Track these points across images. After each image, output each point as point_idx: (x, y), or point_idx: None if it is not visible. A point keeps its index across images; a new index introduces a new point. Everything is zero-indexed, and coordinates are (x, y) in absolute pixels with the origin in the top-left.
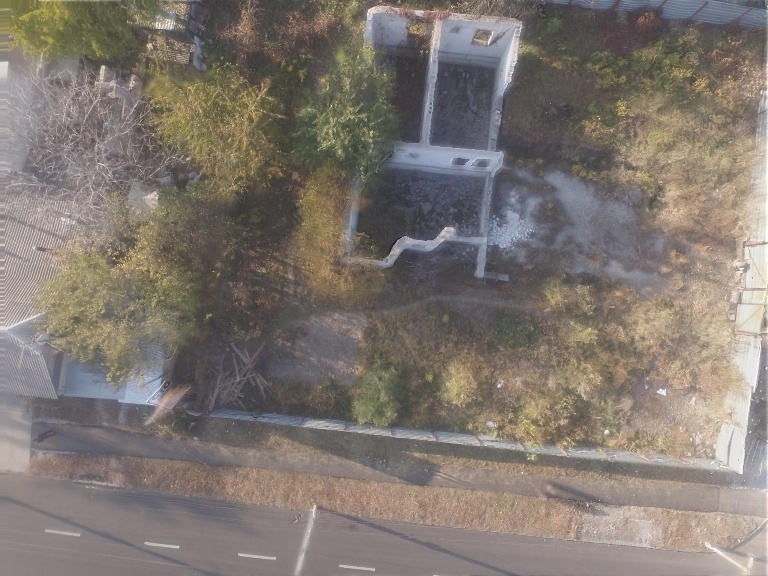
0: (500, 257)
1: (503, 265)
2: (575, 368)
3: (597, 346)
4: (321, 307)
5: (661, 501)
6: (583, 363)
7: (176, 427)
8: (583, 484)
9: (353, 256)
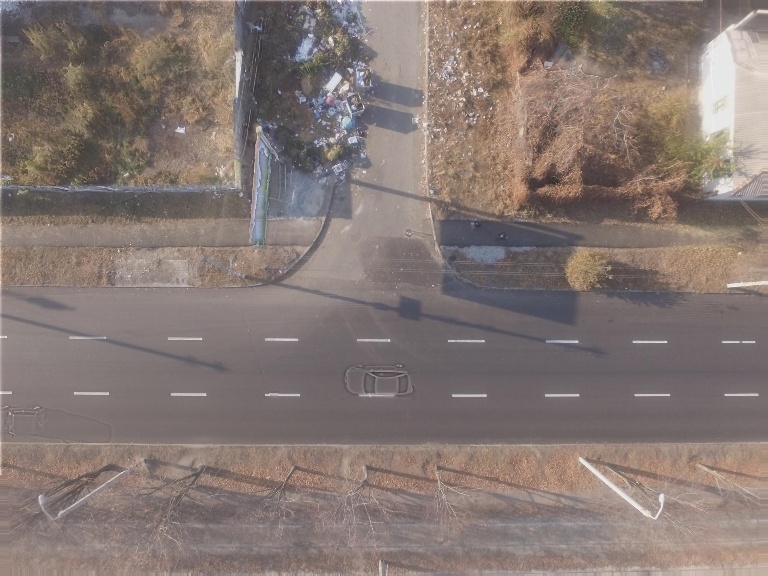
0: (7, 20)
1: (14, 28)
2: (77, 110)
3: (102, 89)
4: None
5: (195, 240)
6: None
7: None
8: (112, 230)
9: None
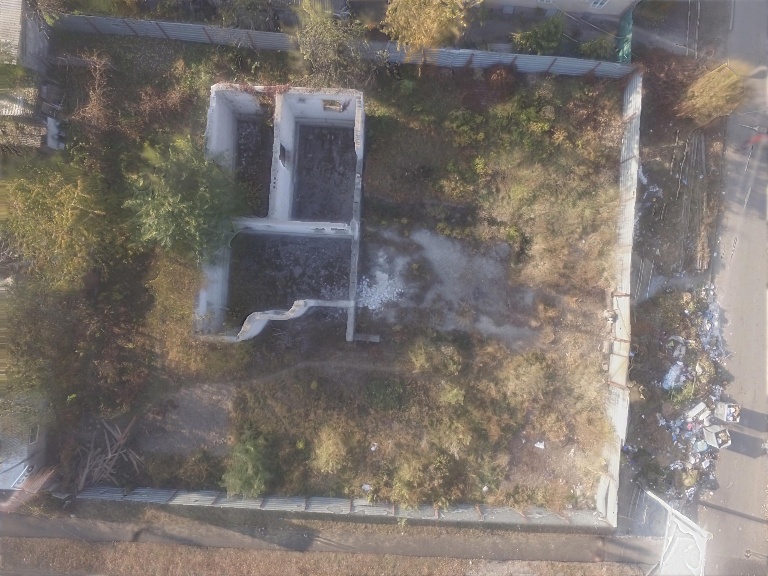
0: (370, 319)
1: (374, 326)
2: (447, 428)
3: (470, 404)
4: (190, 379)
5: (545, 554)
6: (455, 422)
7: (46, 508)
8: (465, 541)
9: (205, 334)
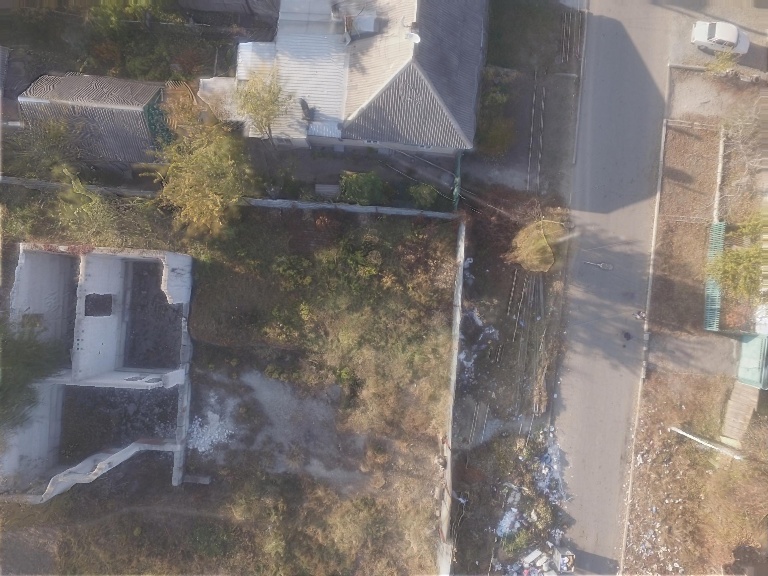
0: (199, 461)
1: (204, 468)
2: (272, 575)
3: (297, 549)
4: None
5: None
6: (281, 569)
7: None
8: None
9: (12, 493)
